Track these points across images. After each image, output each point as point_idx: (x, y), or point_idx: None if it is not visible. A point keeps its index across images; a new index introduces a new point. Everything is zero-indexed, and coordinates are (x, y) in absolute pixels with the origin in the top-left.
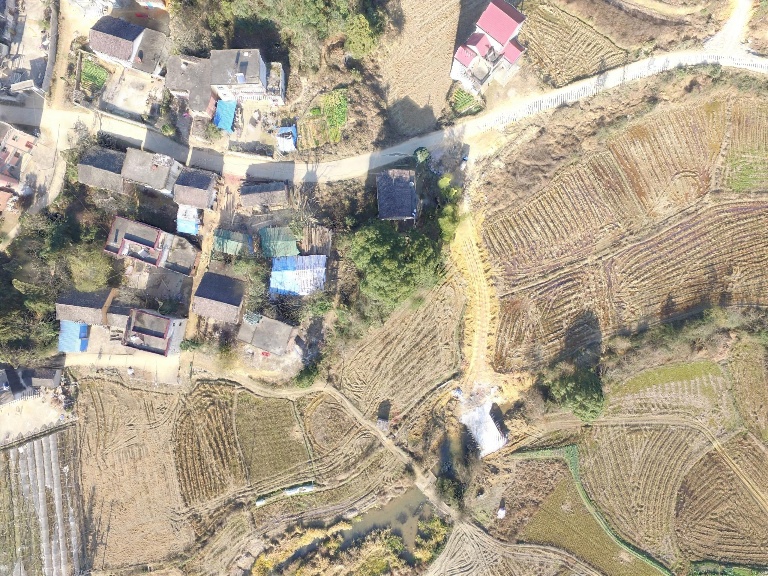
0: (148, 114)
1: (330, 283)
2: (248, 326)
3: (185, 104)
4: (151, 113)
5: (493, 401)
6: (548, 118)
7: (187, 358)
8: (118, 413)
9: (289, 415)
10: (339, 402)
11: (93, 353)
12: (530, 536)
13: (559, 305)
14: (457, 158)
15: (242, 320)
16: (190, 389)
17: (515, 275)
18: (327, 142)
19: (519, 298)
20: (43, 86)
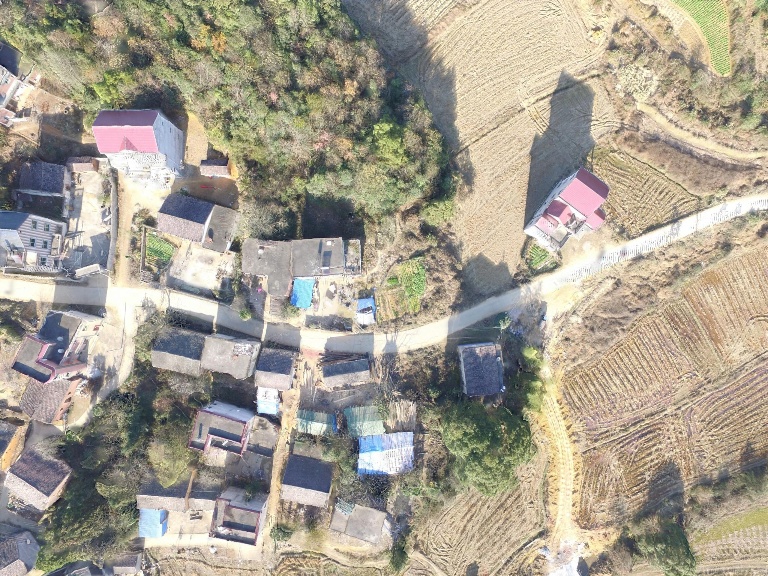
0: (219, 289)
1: (417, 458)
2: (341, 515)
3: (258, 278)
4: (222, 288)
5: (579, 557)
6: (623, 269)
7: None
8: None
9: None
10: (426, 568)
11: (173, 533)
12: None
13: (641, 457)
14: (535, 316)
15: (332, 505)
16: (275, 563)
17: (596, 430)
18: (406, 312)
19: (601, 452)
20: (108, 266)
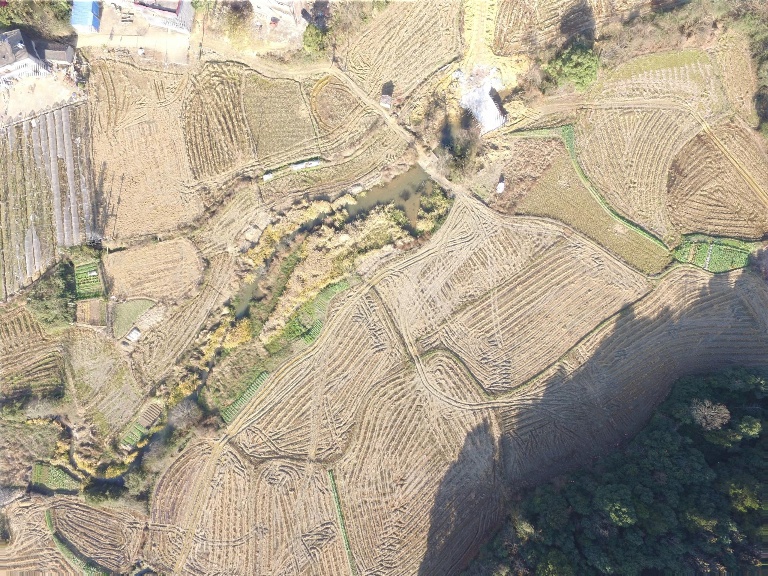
0: None
1: None
2: None
3: None
4: None
5: (492, 84)
6: None
7: (196, 39)
8: (129, 92)
9: (295, 95)
10: (344, 83)
11: (105, 34)
12: (528, 209)
13: None
14: None
15: None
16: (199, 70)
17: None
18: None
19: None
20: None
